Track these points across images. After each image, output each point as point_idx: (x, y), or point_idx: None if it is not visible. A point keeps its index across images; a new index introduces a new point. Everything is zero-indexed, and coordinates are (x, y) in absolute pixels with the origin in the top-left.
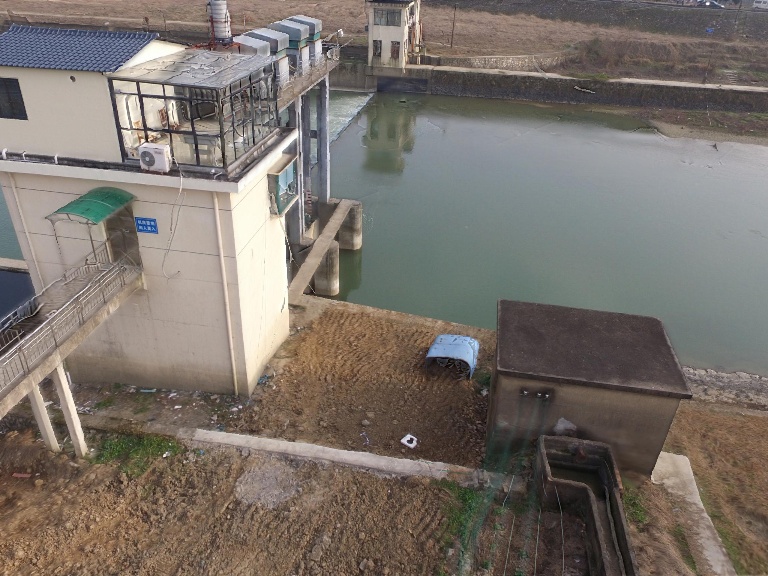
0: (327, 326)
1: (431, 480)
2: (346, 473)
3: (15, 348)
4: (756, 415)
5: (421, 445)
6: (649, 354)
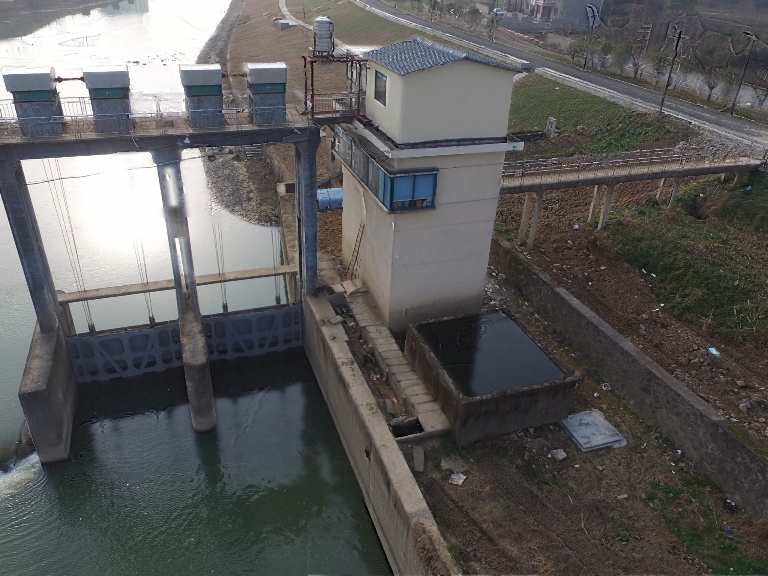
0: (328, 244)
1: None
2: None
3: (553, 159)
4: None
5: None
6: None
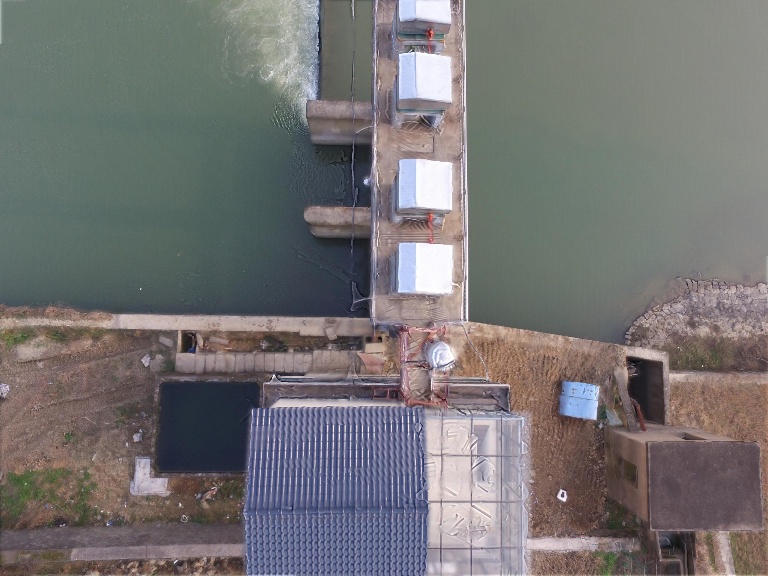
0: (475, 366)
1: (589, 553)
2: (541, 556)
3: None
4: (767, 383)
5: (569, 496)
6: (745, 492)
